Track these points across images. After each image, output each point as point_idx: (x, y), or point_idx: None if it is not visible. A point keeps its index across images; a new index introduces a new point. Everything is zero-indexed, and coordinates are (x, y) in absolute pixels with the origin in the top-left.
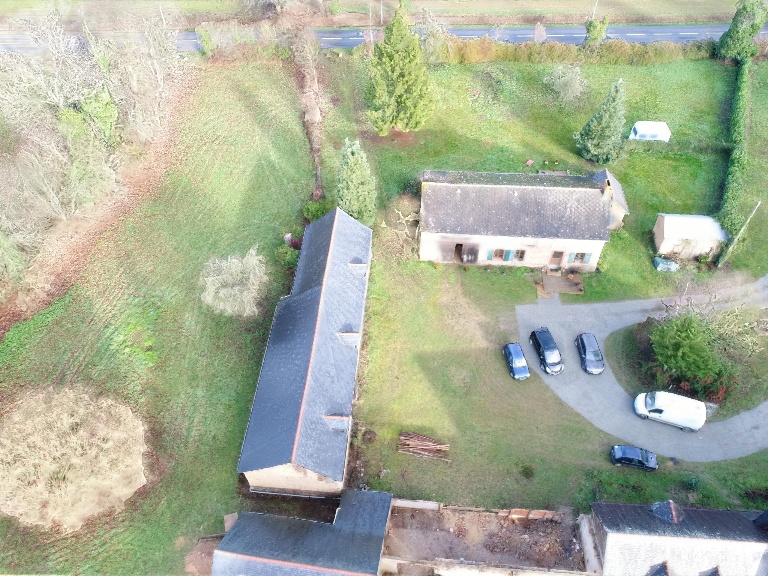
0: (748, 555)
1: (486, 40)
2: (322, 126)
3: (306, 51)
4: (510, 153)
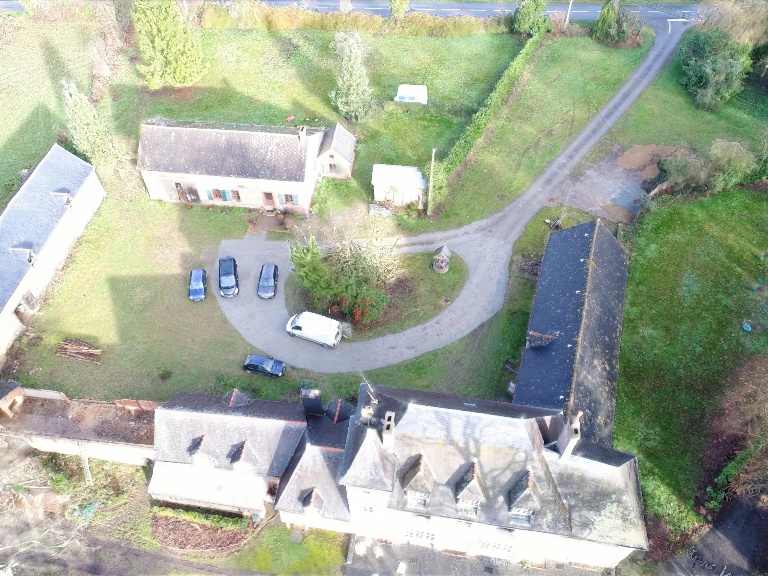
0: (270, 431)
1: (294, 9)
2: (110, 80)
3: (107, 11)
4: (277, 110)
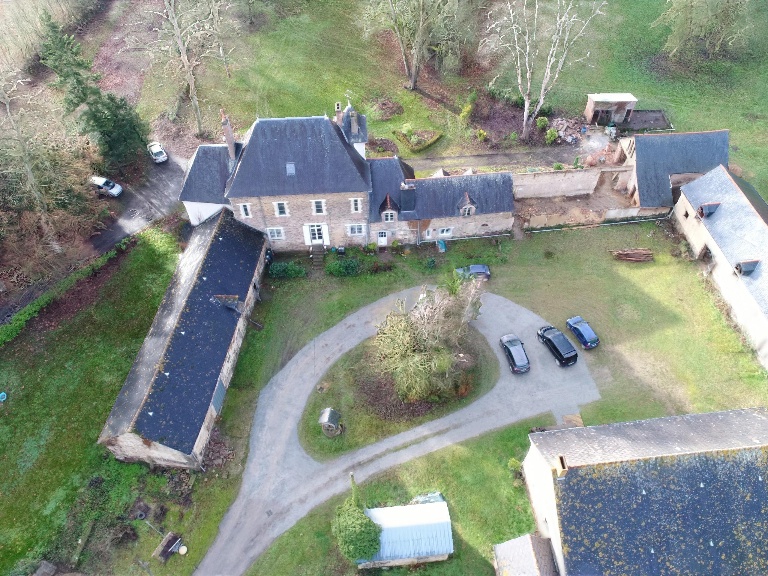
0: None
1: None
2: None
3: None
4: None
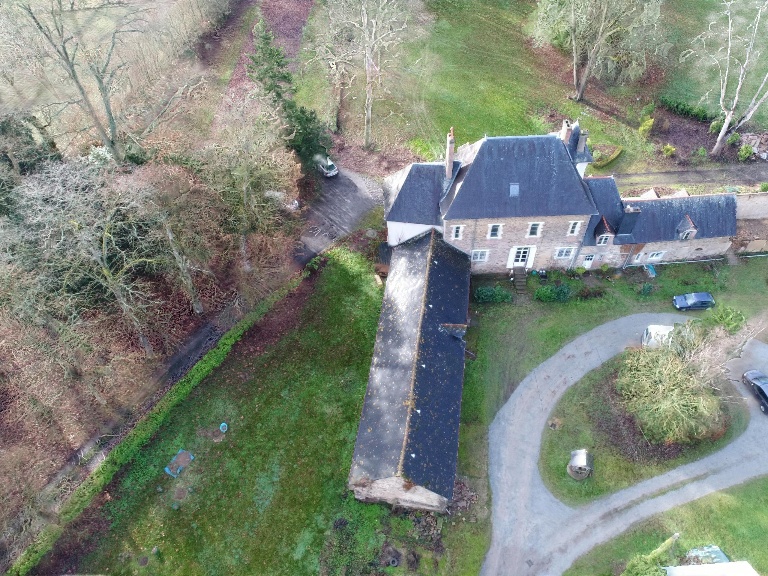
0: None
1: None
2: None
3: None
4: None
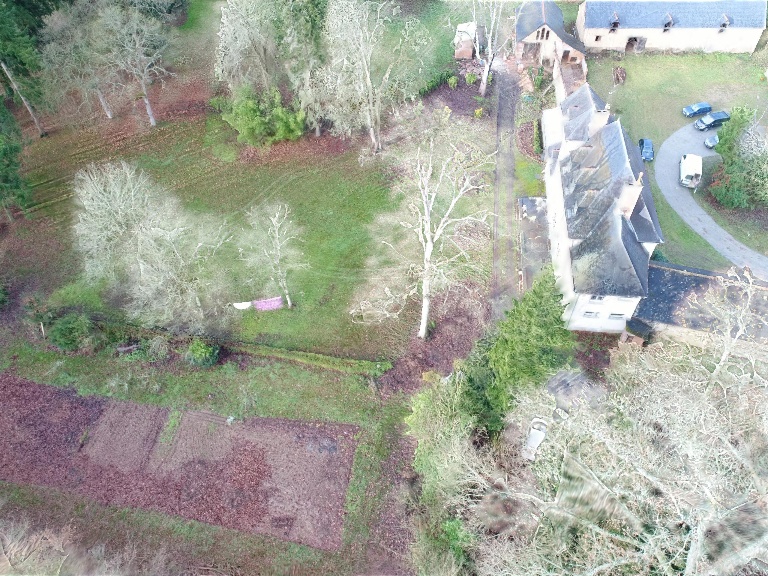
0: None
1: None
2: None
3: None
4: None
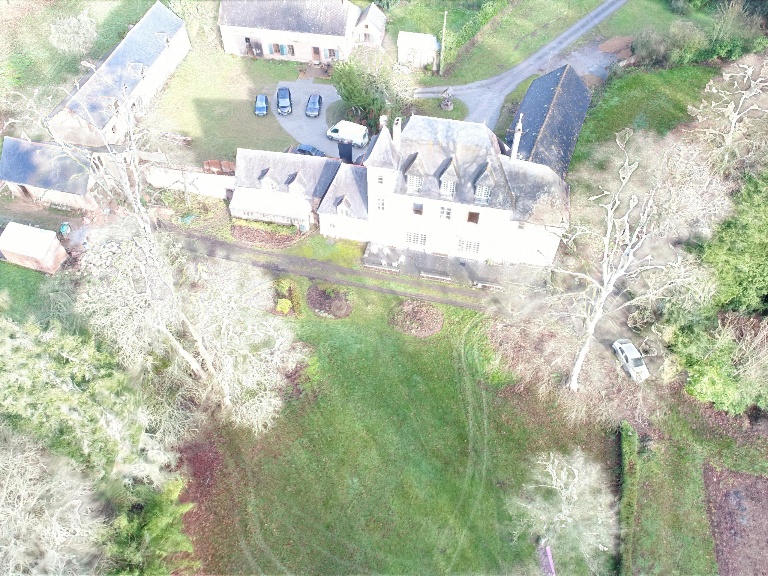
0: (316, 164)
1: None
2: None
3: None
4: None
